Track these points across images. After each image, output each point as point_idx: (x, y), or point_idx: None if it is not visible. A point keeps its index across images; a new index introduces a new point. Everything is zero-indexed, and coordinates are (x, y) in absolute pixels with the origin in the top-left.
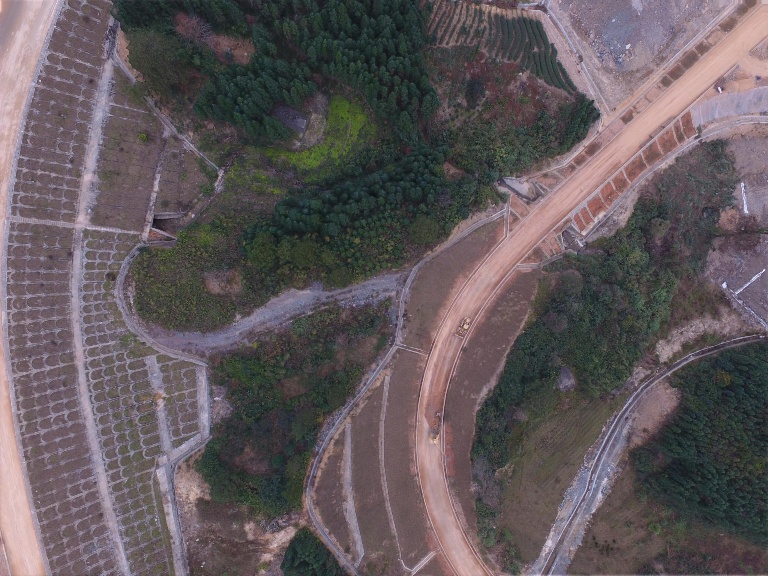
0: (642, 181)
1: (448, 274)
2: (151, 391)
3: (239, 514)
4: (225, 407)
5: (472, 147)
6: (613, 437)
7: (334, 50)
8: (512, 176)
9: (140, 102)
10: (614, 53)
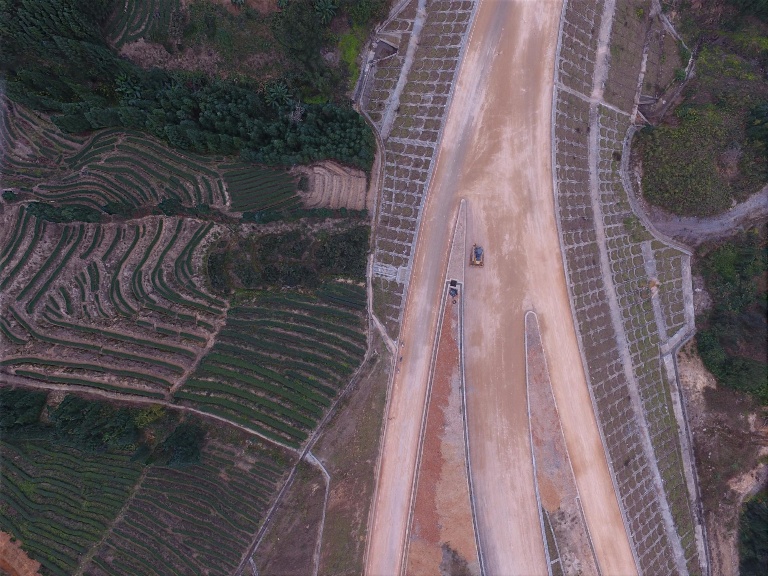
0: None
1: None
2: (646, 278)
3: (745, 404)
4: (705, 299)
5: None
6: None
7: None
8: None
9: None
10: None
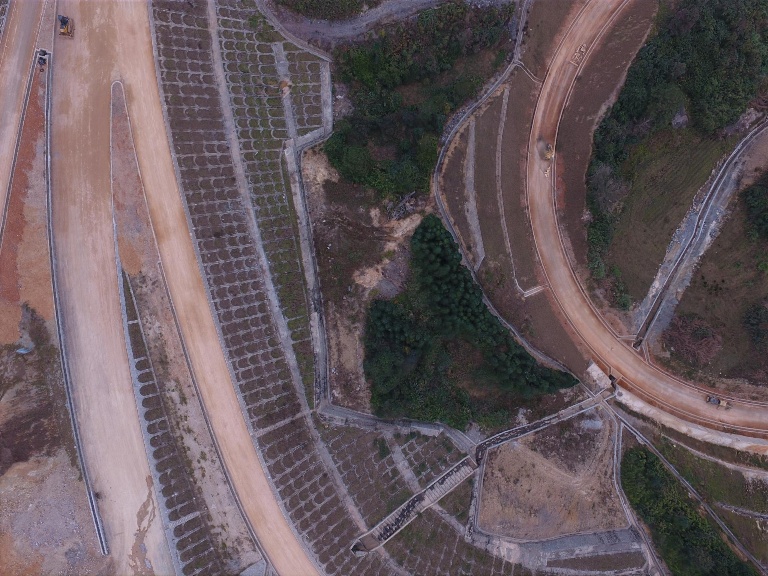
0: None
1: None
2: (277, 78)
3: (366, 198)
4: (347, 106)
5: None
6: (722, 182)
7: None
8: None
9: None
10: None
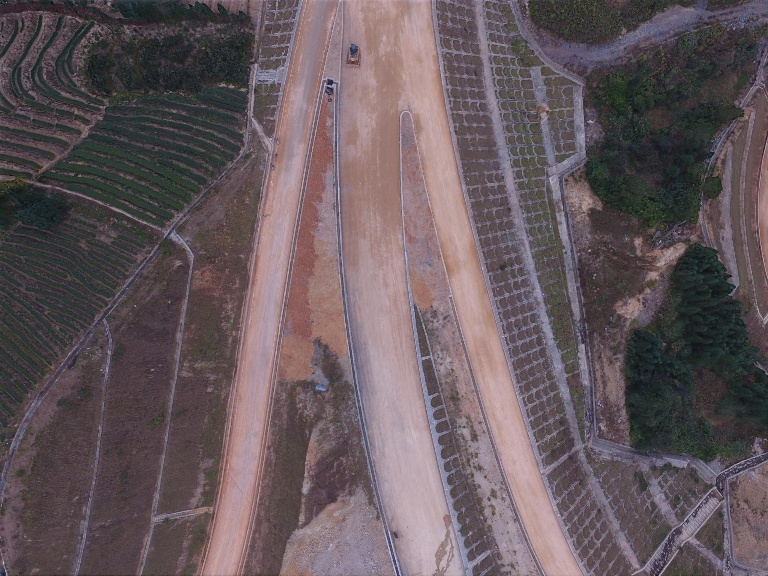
0: None
1: None
2: (536, 103)
3: (630, 227)
4: (598, 131)
5: None
6: None
7: None
8: None
9: None
10: None
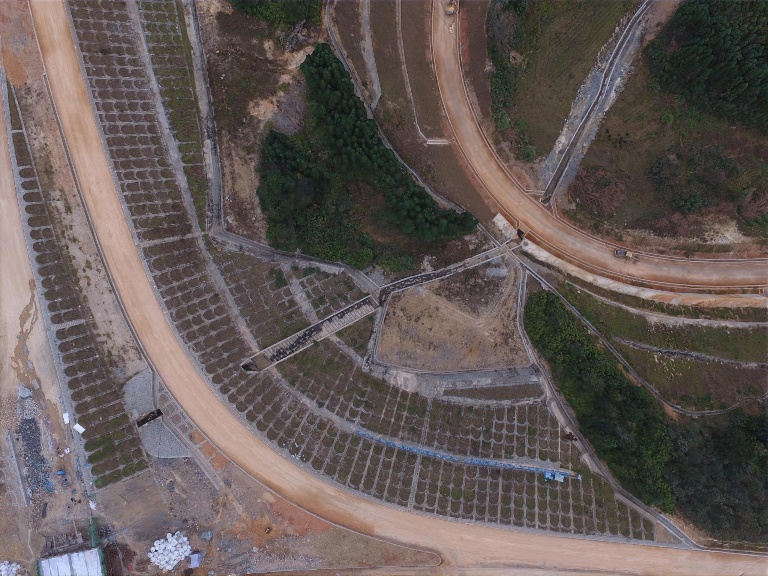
0: None
1: None
2: None
3: (259, 30)
4: None
5: None
6: (626, 40)
7: None
8: None
9: None
10: None
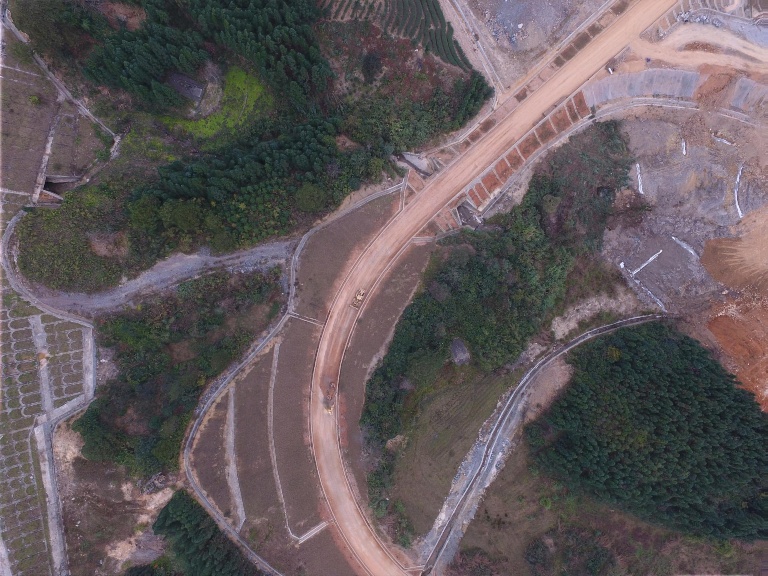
0: (536, 159)
1: (342, 245)
2: (34, 350)
3: (116, 474)
4: (111, 369)
5: (367, 120)
6: (509, 412)
7: (223, 19)
8: (411, 151)
9: (32, 65)
10: (508, 32)
